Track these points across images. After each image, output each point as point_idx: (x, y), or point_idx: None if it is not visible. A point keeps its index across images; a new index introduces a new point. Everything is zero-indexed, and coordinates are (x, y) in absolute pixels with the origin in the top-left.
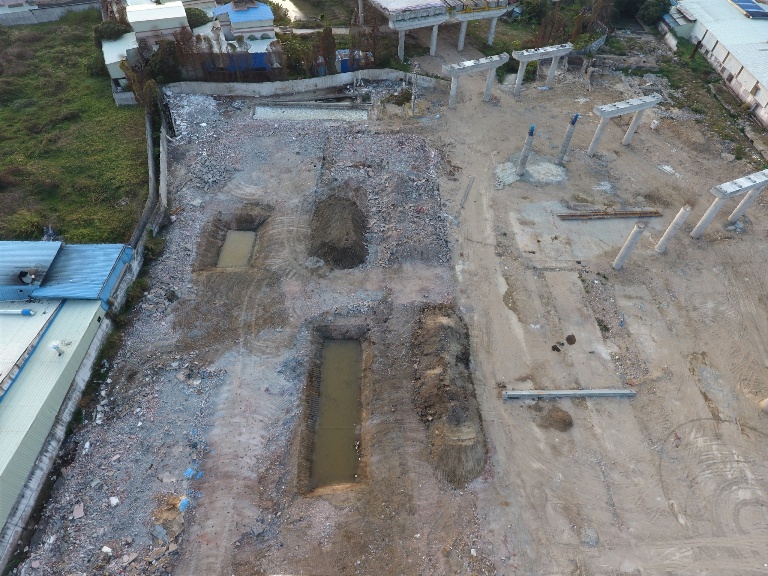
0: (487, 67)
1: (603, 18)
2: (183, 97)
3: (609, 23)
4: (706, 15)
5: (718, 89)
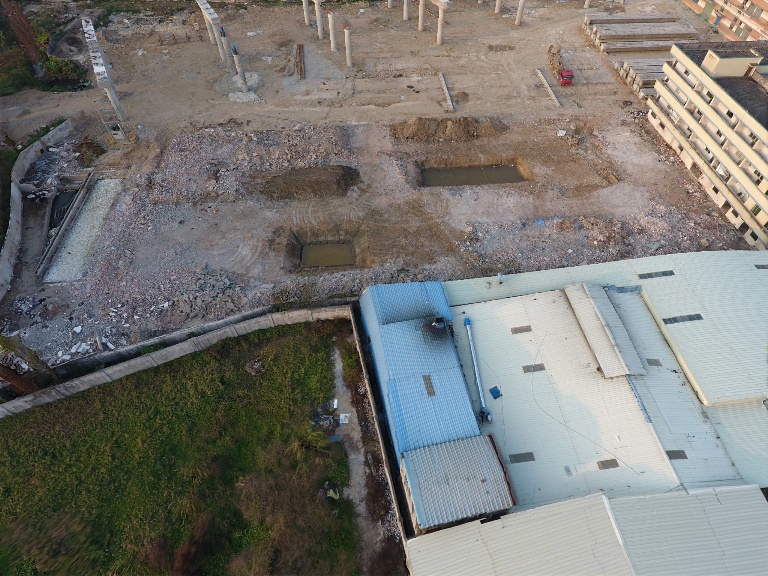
0: None
1: None
2: None
3: None
4: None
5: None
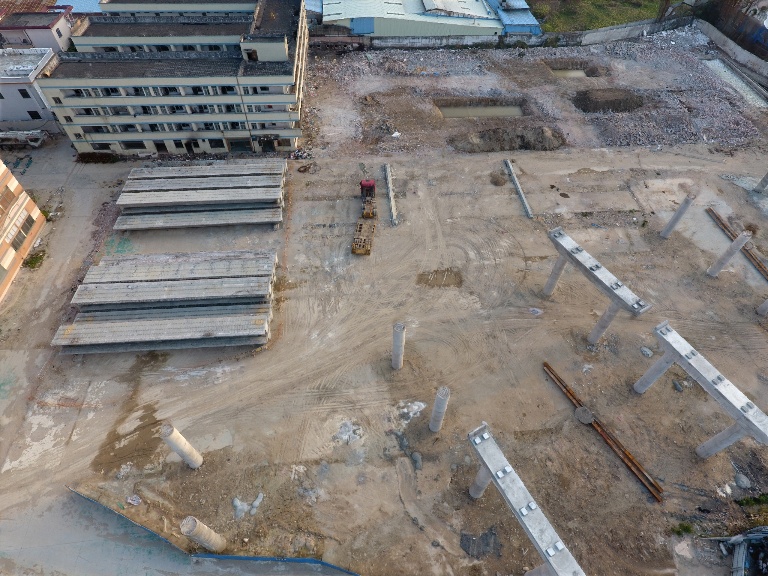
0: None
1: None
2: (696, 31)
3: None
4: None
5: None
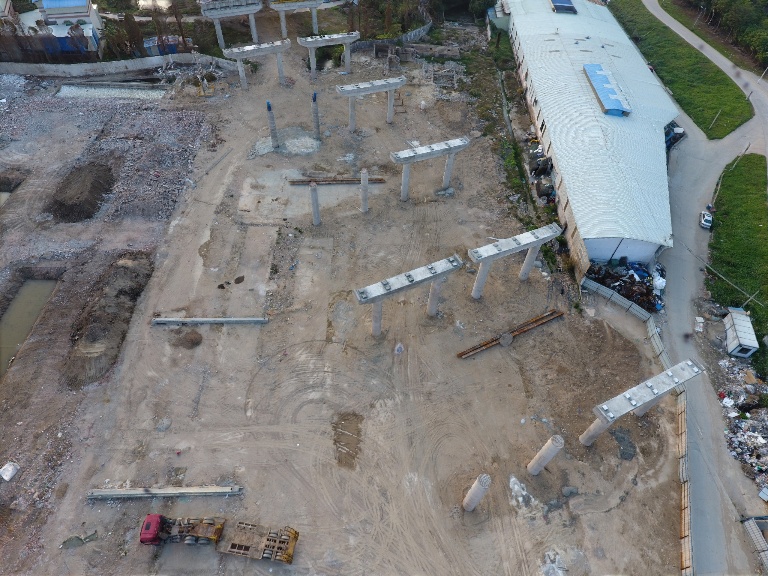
0: (269, 52)
1: (432, 10)
2: None
3: (442, 15)
4: (520, 9)
5: (507, 76)
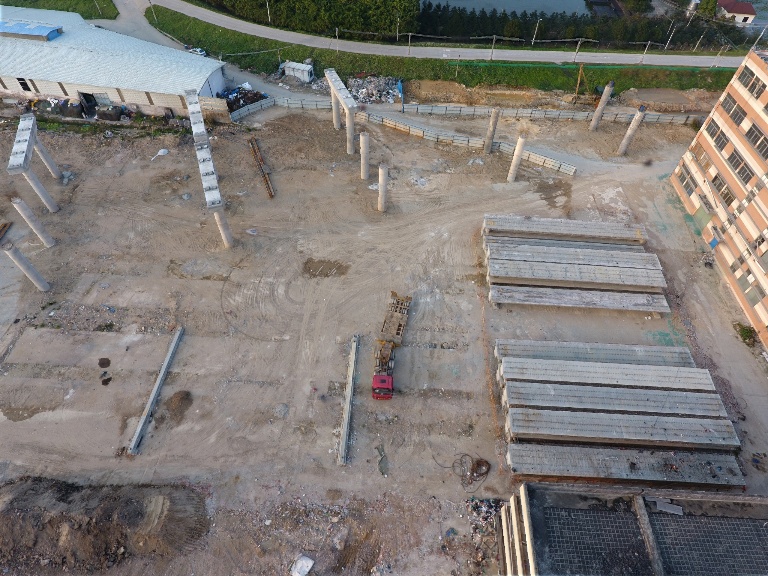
0: None
1: None
2: None
3: None
4: None
5: None
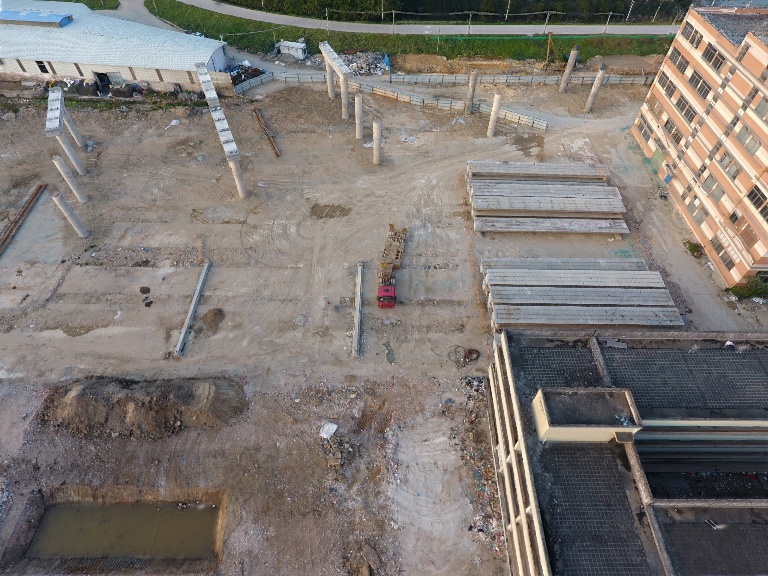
0: None
1: None
2: None
3: None
4: None
5: None
